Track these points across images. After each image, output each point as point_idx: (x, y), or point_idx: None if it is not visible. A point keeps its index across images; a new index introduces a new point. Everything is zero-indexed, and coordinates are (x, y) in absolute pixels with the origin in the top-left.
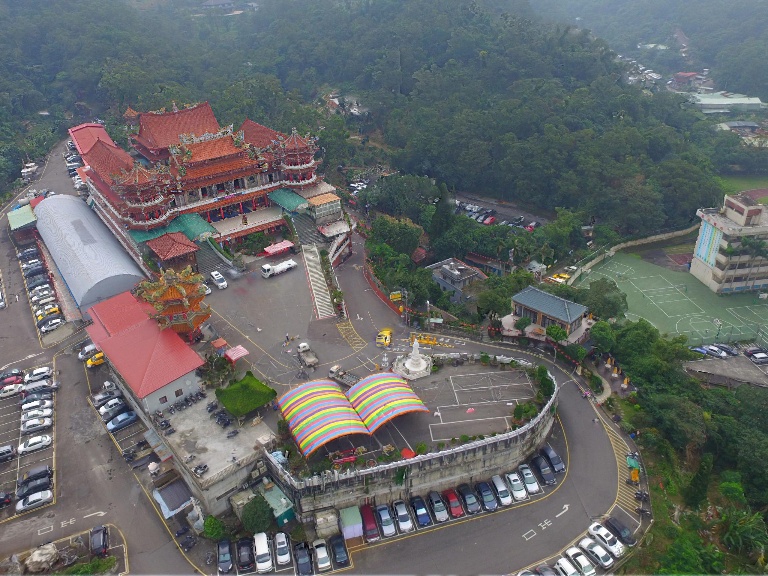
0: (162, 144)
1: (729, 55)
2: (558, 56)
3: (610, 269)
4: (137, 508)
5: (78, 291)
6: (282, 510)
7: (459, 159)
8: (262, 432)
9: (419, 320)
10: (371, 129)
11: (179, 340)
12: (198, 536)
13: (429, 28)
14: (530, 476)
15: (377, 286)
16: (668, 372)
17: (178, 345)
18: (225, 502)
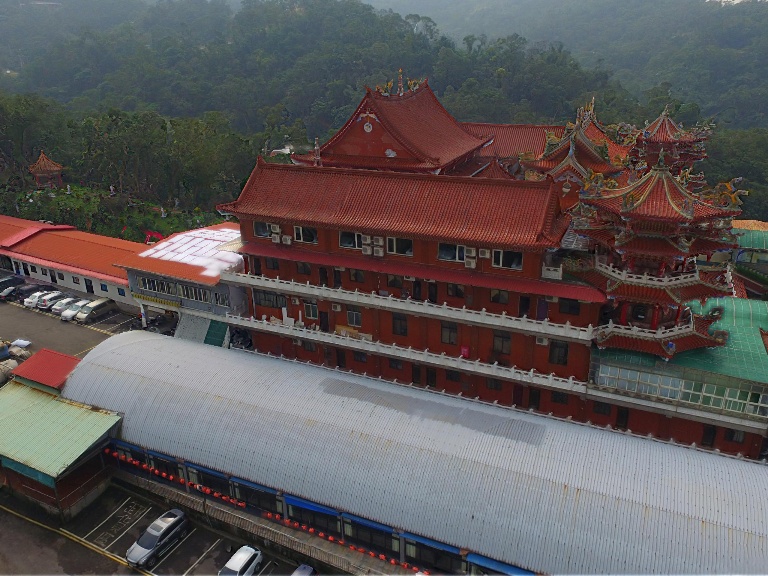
0: None
1: None
2: None
3: None
4: None
5: None
6: None
7: None
8: None
9: None
10: None
11: None
12: None
13: (393, 52)
14: None
15: None
16: None
17: None
18: None
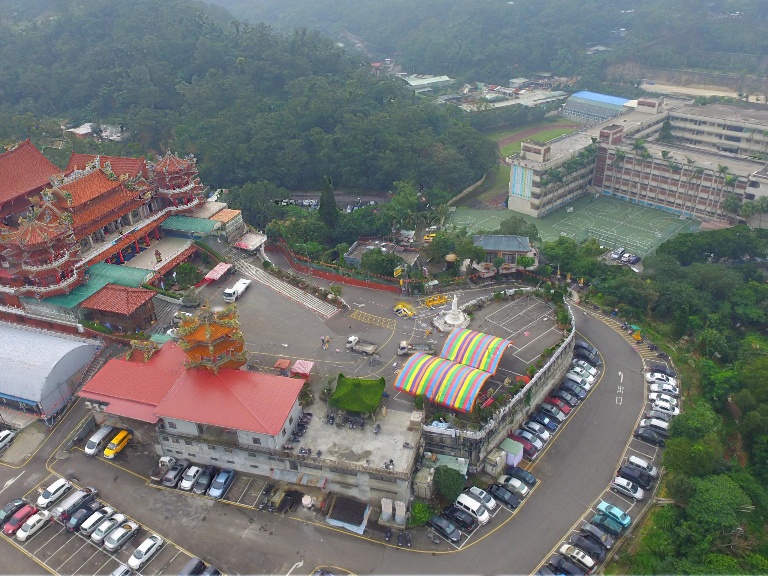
0: (1, 197)
1: (407, 45)
2: (305, 56)
3: (457, 221)
4: (327, 541)
5: (24, 386)
6: (465, 467)
7: (278, 160)
8: (398, 417)
9: (419, 287)
10: (142, 153)
11: (249, 374)
12: (405, 530)
13: (164, 41)
14: (587, 364)
15: (345, 276)
16: (600, 266)
17: (254, 378)
18: (409, 489)
